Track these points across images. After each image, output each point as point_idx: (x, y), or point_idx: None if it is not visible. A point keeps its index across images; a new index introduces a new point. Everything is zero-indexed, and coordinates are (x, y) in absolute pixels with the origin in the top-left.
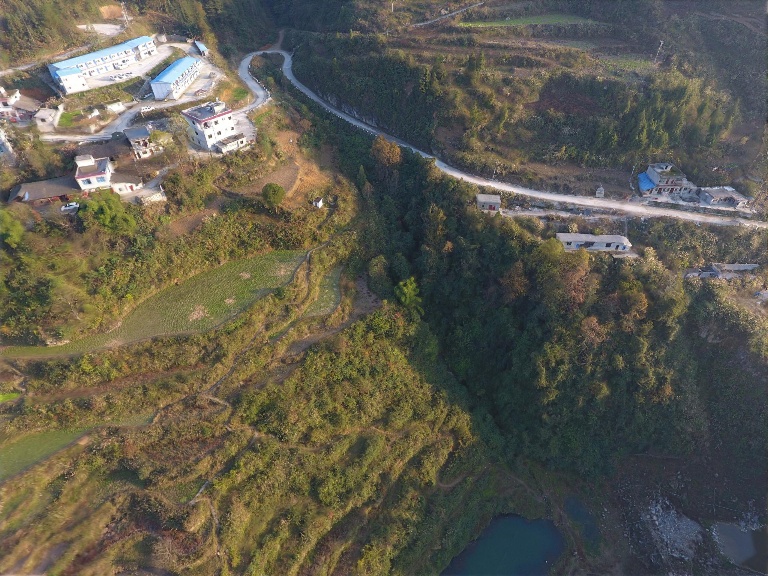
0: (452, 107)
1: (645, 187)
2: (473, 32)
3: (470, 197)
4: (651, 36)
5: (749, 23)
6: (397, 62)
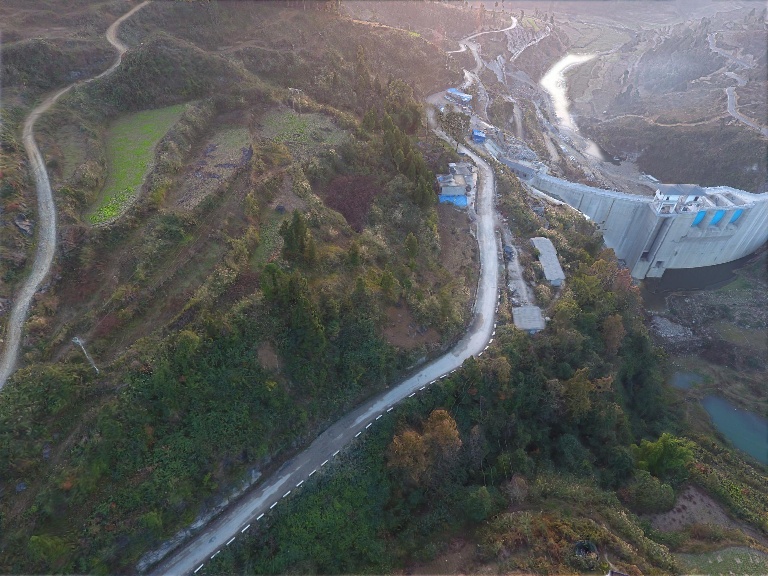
0: (368, 302)
1: (464, 202)
2: (146, 212)
3: (530, 336)
4: (254, 91)
5: (255, 45)
6: (193, 356)
